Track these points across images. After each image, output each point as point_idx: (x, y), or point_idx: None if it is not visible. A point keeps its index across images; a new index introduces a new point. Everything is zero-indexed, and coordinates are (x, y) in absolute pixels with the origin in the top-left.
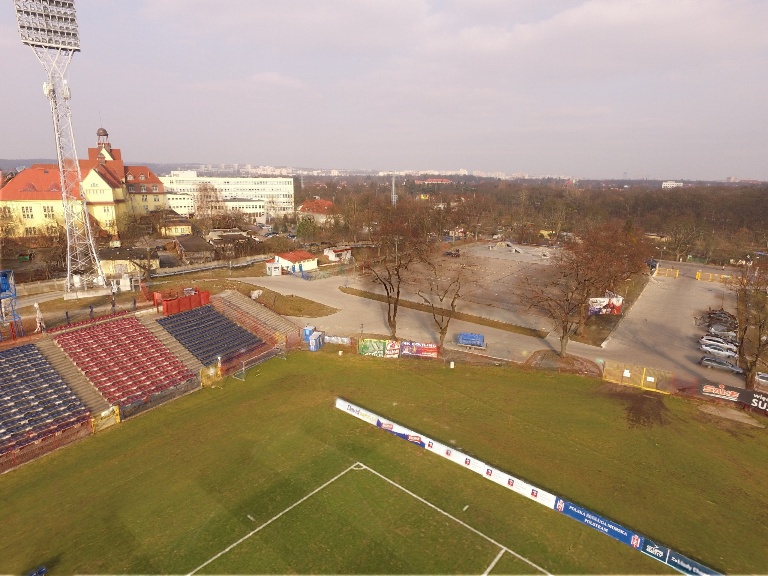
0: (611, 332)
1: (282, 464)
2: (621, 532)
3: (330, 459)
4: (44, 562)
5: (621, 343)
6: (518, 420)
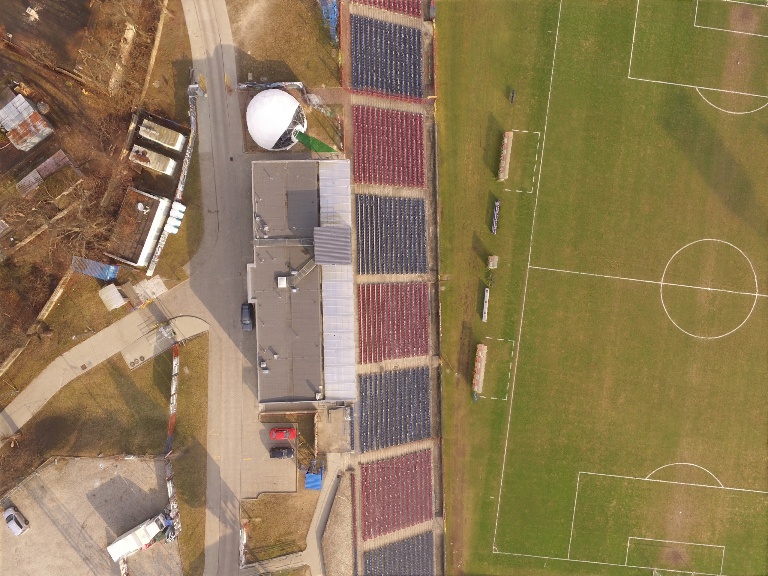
0: None
1: None
2: None
3: None
4: (506, 89)
5: None
6: None
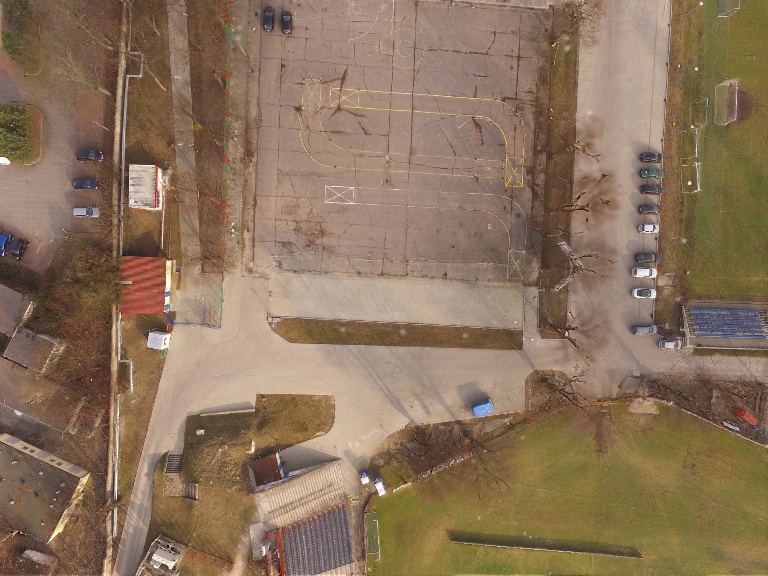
0: (568, 298)
1: None
2: None
3: None
4: None
5: (577, 315)
6: (546, 492)
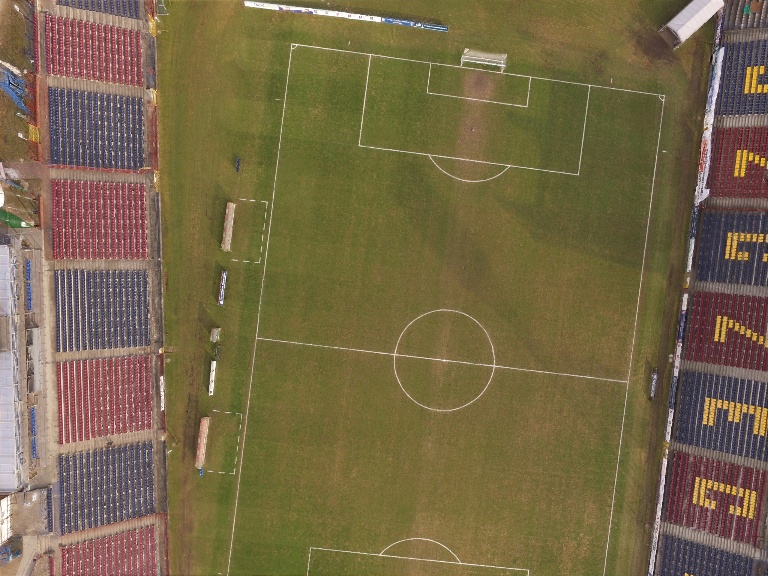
0: None
1: (261, 66)
2: (407, 22)
3: (279, 50)
4: (232, 157)
5: None
6: None
